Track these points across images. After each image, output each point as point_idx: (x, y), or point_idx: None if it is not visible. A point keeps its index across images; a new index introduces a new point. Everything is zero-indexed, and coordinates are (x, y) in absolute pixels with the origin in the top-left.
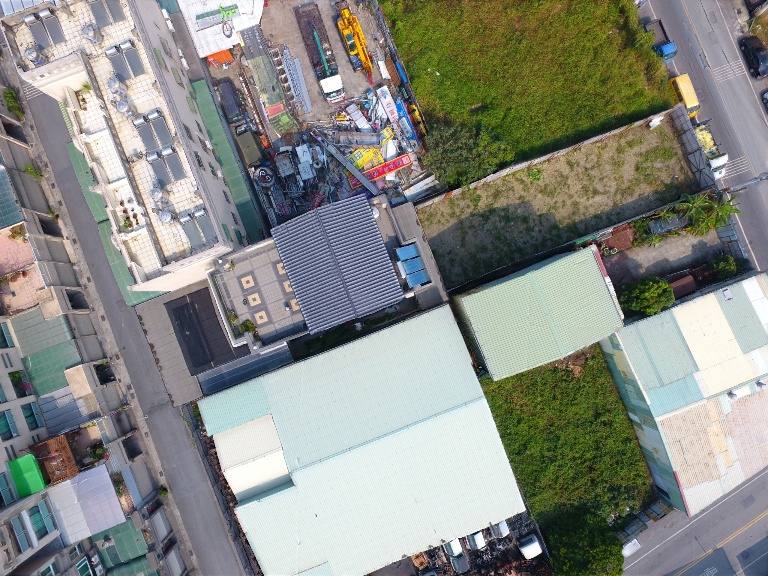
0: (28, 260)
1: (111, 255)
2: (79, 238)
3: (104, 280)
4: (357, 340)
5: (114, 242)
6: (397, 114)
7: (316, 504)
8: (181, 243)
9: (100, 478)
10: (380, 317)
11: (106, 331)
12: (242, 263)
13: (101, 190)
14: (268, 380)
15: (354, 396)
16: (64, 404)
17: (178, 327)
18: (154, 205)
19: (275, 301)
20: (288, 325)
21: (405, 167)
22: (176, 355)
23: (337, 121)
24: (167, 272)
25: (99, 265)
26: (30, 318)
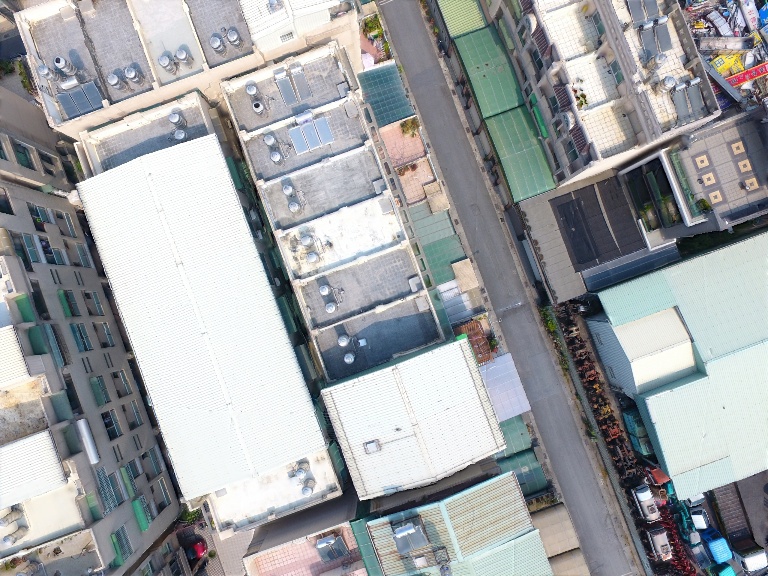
0: (413, 155)
1: (502, 150)
2: (432, 142)
3: (458, 184)
4: (758, 236)
5: (571, 119)
6: (757, 22)
7: (725, 396)
8: (666, 114)
9: (506, 366)
10: (739, 224)
11: (459, 235)
12: (696, 143)
13: (560, 67)
14: (670, 273)
15: (760, 290)
16: (449, 298)
17: (563, 224)
18: (639, 76)
19: (730, 181)
20: (742, 205)
21: (762, 76)
22: (560, 251)
23: (694, 29)
24: (614, 152)
25: (452, 169)
26: (416, 212)
